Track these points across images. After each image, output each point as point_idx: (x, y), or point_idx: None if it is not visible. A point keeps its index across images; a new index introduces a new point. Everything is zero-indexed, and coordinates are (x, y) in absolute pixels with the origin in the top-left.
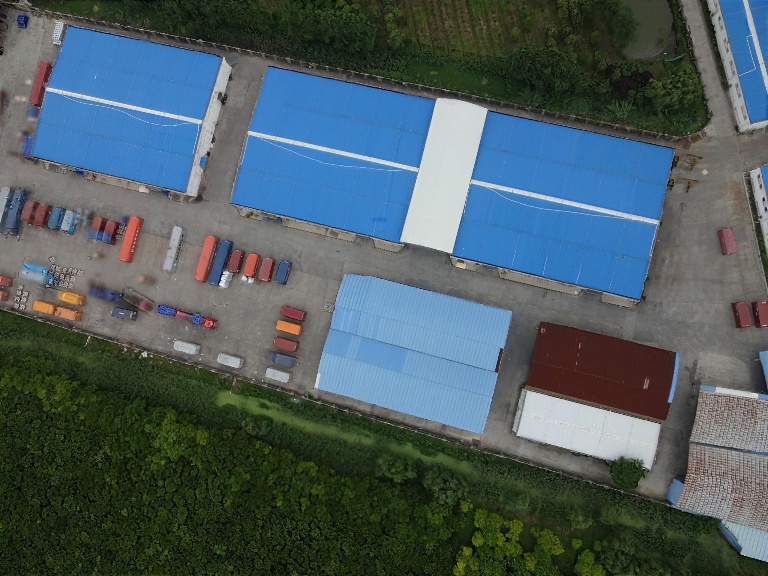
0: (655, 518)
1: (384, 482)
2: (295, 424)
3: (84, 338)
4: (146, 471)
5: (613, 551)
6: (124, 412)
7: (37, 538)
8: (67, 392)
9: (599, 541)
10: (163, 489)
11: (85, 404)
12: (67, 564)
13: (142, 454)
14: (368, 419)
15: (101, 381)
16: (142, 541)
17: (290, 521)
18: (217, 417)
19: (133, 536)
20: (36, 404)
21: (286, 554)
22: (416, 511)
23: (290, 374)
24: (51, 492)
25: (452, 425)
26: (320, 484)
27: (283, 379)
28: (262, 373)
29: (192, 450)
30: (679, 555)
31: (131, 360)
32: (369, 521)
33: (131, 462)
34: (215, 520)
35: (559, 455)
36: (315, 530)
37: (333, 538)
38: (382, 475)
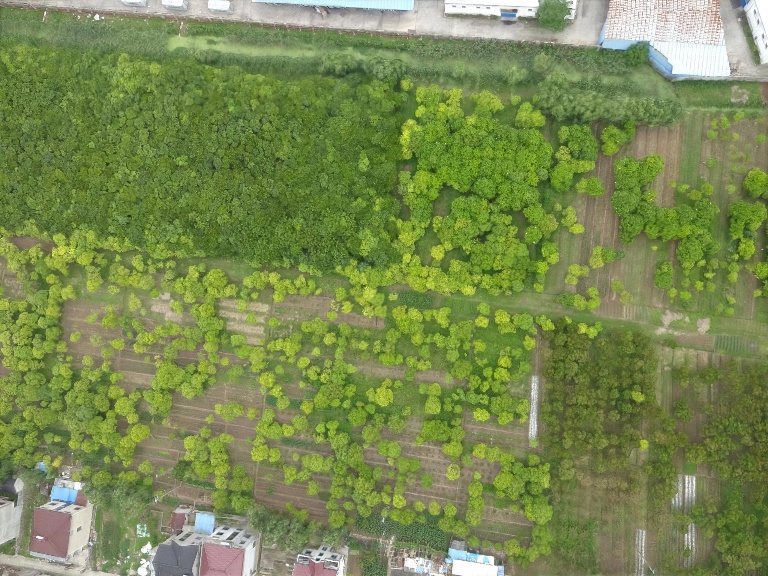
0: (588, 62)
1: (327, 76)
2: (242, 52)
3: (40, 14)
4: (107, 106)
5: (547, 86)
6: (81, 60)
7: (17, 183)
8: (28, 53)
9: (536, 93)
10: (124, 117)
11: (45, 59)
12: (46, 200)
13: (102, 92)
14: (308, 31)
15: (60, 47)
16: (110, 166)
17: (242, 121)
18: (169, 57)
19: (102, 162)
20: (1, 67)
21: (242, 149)
22: (358, 90)
23: (231, 4)
24: (24, 139)
25: (384, 7)
26: (267, 85)
27: (224, 7)
28: (206, 12)
29: (146, 79)
30: (615, 94)
31: (85, 23)
32: (316, 109)
33: (93, 101)
34: (175, 136)
35: (491, 27)
36: (266, 124)
37: (284, 129)
38: (324, 70)
